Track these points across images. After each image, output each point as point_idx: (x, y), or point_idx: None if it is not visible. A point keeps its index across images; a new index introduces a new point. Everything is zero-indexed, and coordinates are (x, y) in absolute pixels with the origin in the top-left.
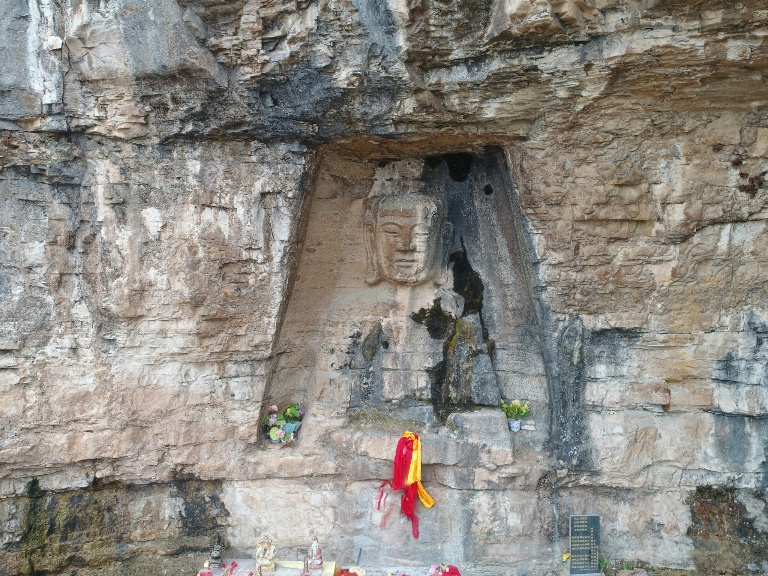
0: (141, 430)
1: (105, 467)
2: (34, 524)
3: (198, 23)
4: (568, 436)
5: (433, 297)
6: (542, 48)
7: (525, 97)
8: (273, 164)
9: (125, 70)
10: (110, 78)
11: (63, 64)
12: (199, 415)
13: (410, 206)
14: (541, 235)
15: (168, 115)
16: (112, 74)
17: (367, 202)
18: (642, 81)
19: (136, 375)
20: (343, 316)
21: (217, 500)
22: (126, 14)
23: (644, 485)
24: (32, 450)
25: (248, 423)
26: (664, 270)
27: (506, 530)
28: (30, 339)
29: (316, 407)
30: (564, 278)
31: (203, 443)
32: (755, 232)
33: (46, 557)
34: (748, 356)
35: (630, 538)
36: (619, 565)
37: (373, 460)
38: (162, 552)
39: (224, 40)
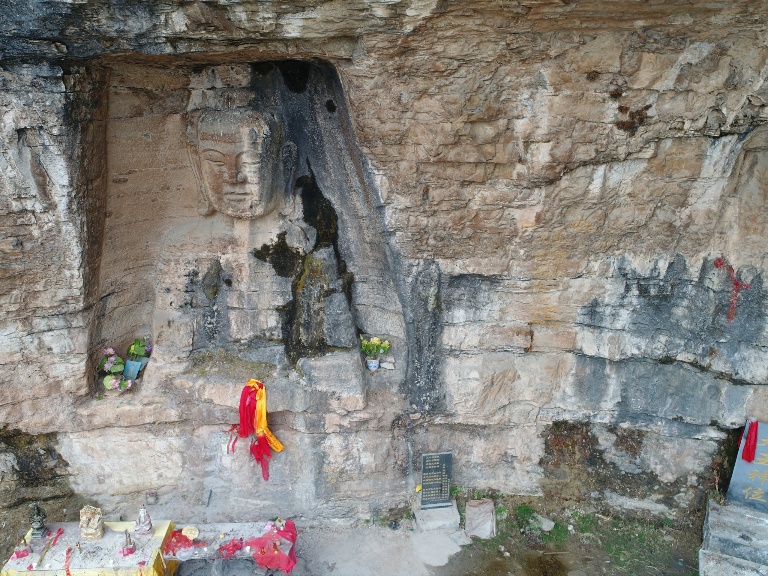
0: None
1: None
2: None
3: None
4: (422, 381)
5: (277, 231)
6: None
7: (333, 13)
8: (21, 92)
9: None
10: None
11: None
12: (11, 374)
13: (232, 129)
14: (383, 176)
15: None
16: None
17: (186, 117)
18: None
19: None
20: (174, 253)
21: (53, 451)
22: None
23: (500, 422)
24: None
25: (73, 376)
26: (527, 215)
27: (359, 468)
28: None
29: (156, 350)
30: (413, 224)
31: (23, 401)
32: (634, 171)
33: None
34: (615, 302)
35: (484, 468)
36: (471, 493)
37: (218, 407)
38: None
39: None
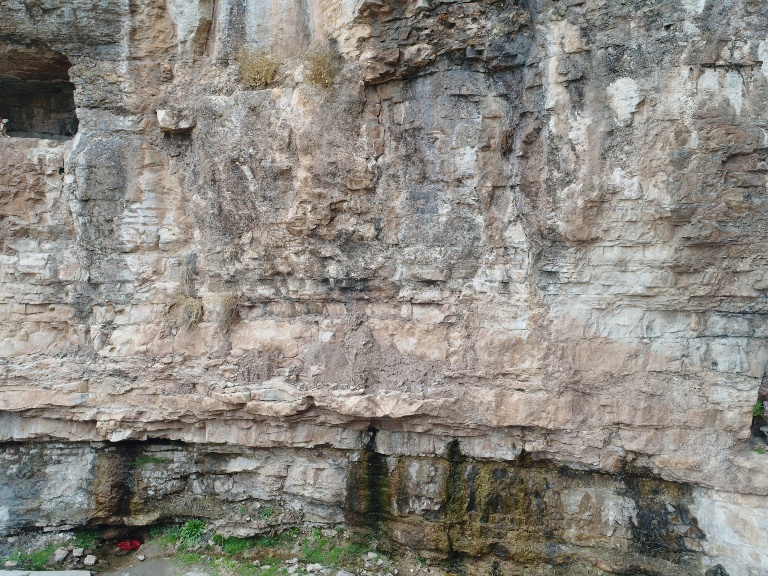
0: (582, 397)
1: (536, 439)
2: (453, 494)
3: None
4: None
5: None
6: None
7: None
8: None
9: None
10: None
11: None
12: (664, 387)
13: None
14: None
15: None
16: None
17: None
18: None
19: (581, 322)
20: None
21: (684, 512)
22: None
23: None
24: (456, 404)
25: (739, 408)
26: None
27: None
28: (457, 268)
29: None
30: None
31: (668, 427)
32: None
33: (465, 536)
34: None
35: None
36: None
37: None
38: (606, 567)
39: None
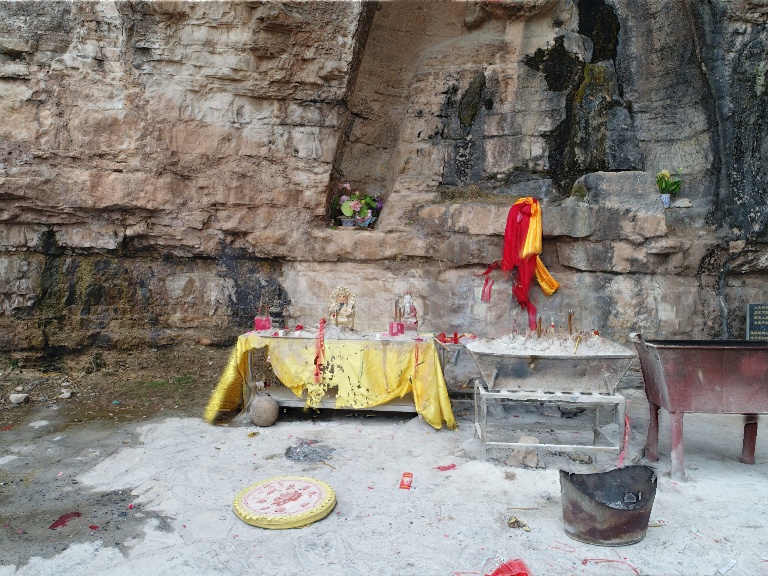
0: (182, 182)
1: (137, 223)
2: (50, 288)
3: None
4: (746, 196)
5: (553, 35)
6: None
7: None
8: None
9: None
10: None
11: None
12: (254, 170)
13: None
14: None
15: None
16: None
17: None
18: None
19: (176, 103)
20: (435, 66)
21: None
22: None
23: None
24: (46, 184)
25: (315, 188)
26: None
27: (656, 325)
28: (45, 40)
29: (399, 183)
30: None
31: (259, 207)
32: None
33: (64, 331)
34: None
35: None
36: None
37: (475, 237)
38: (207, 340)
39: None
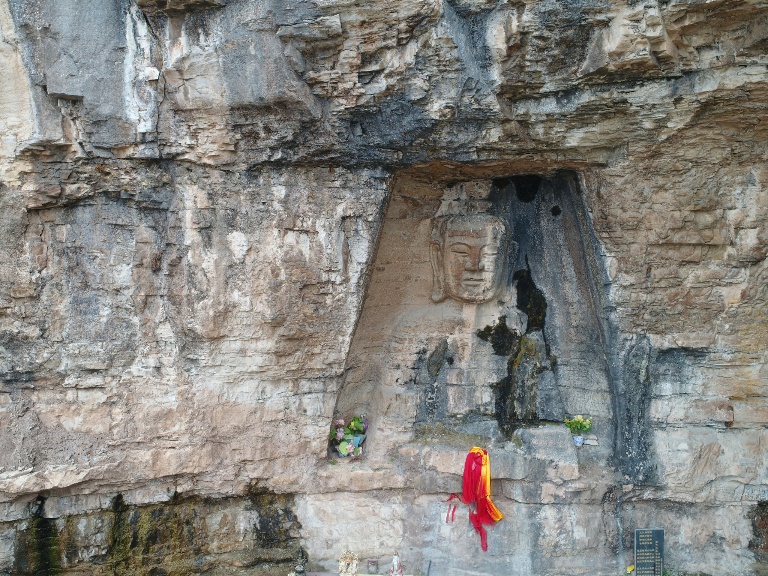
0: (219, 446)
1: (186, 482)
2: (118, 537)
3: (298, 57)
4: (634, 452)
5: (498, 315)
6: (634, 82)
7: (610, 127)
8: (355, 189)
9: (221, 101)
10: (204, 108)
11: (158, 94)
12: (274, 431)
13: (480, 227)
14: (614, 258)
15: (258, 143)
16: (207, 104)
17: (434, 221)
18: (729, 114)
19: (216, 393)
20: (409, 333)
21: (289, 513)
22: (227, 48)
23: (706, 500)
24: (119, 466)
25: (320, 438)
26: (733, 292)
27: (572, 543)
28: (117, 359)
29: (383, 422)
30: (634, 299)
31: (277, 458)
32: None
33: (130, 569)
34: None
35: (692, 551)
36: None
37: (441, 474)
38: (239, 564)
39: (323, 74)
